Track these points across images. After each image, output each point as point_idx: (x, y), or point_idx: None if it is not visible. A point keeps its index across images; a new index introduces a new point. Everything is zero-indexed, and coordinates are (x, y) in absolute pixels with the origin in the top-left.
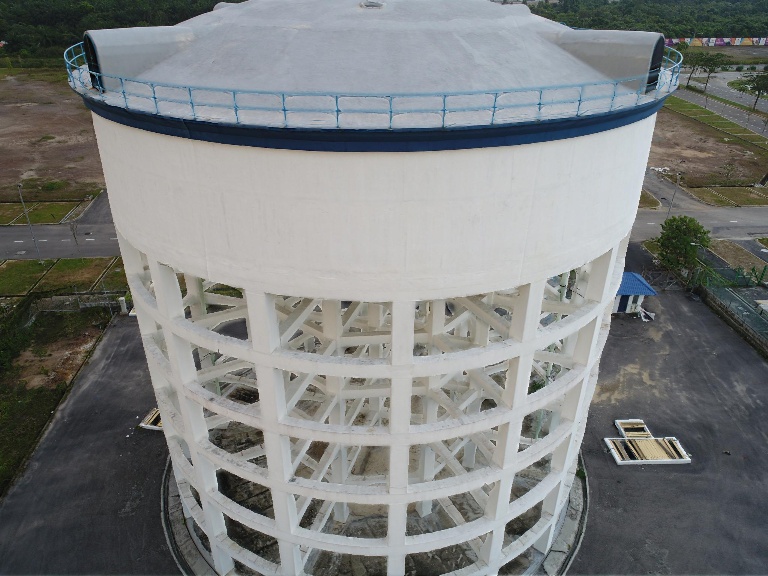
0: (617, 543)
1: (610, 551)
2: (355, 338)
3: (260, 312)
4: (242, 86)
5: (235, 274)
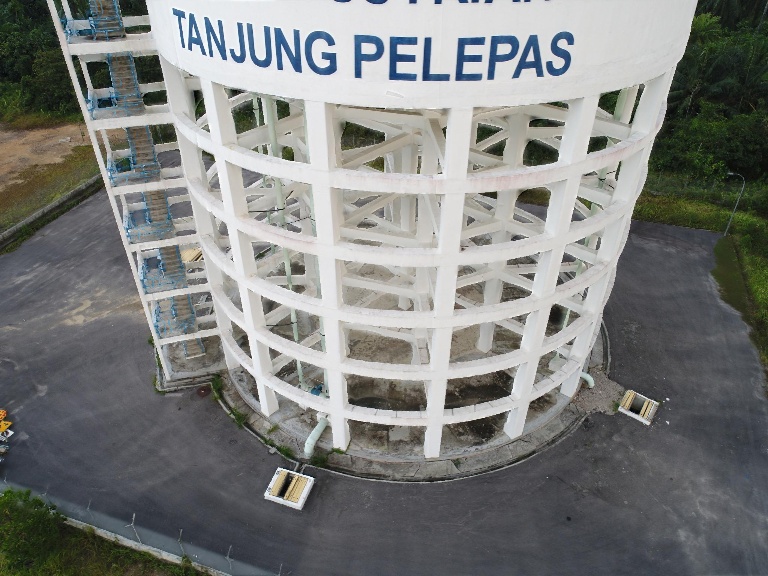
0: None
1: None
2: None
3: None
4: None
5: None
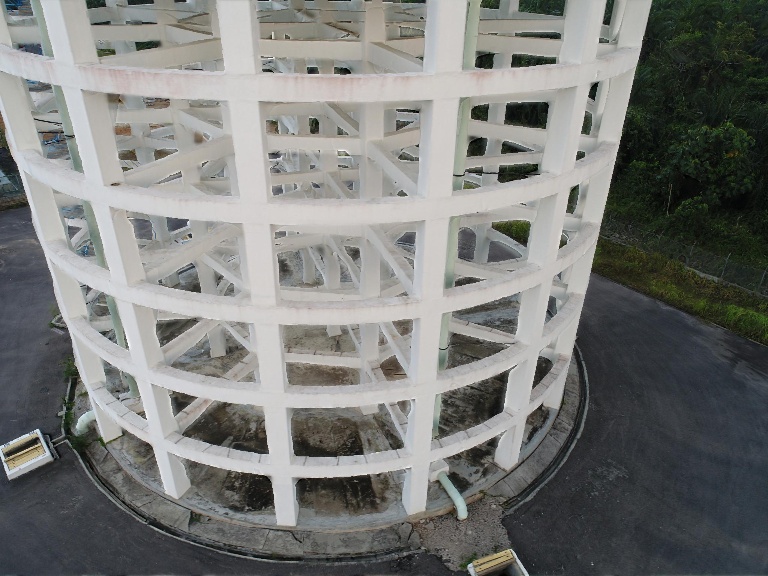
0: None
1: None
2: None
3: None
4: None
5: None
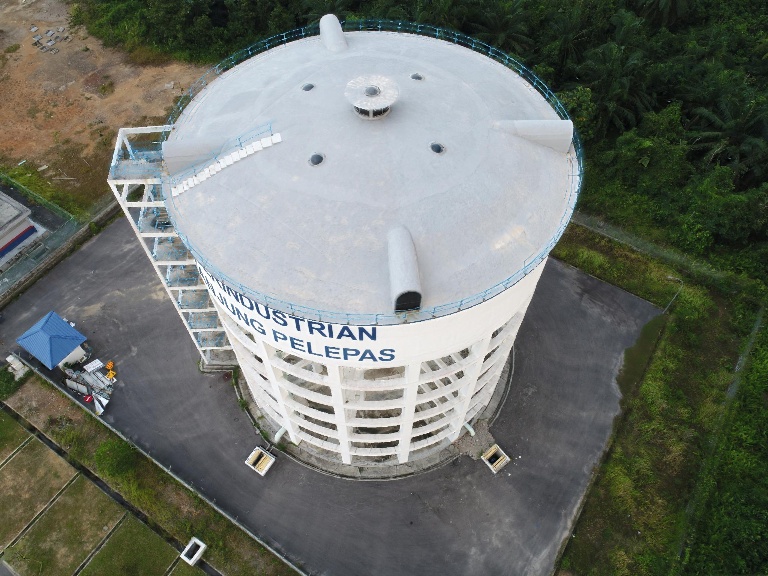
0: None
1: None
2: None
3: None
4: (509, 86)
5: None
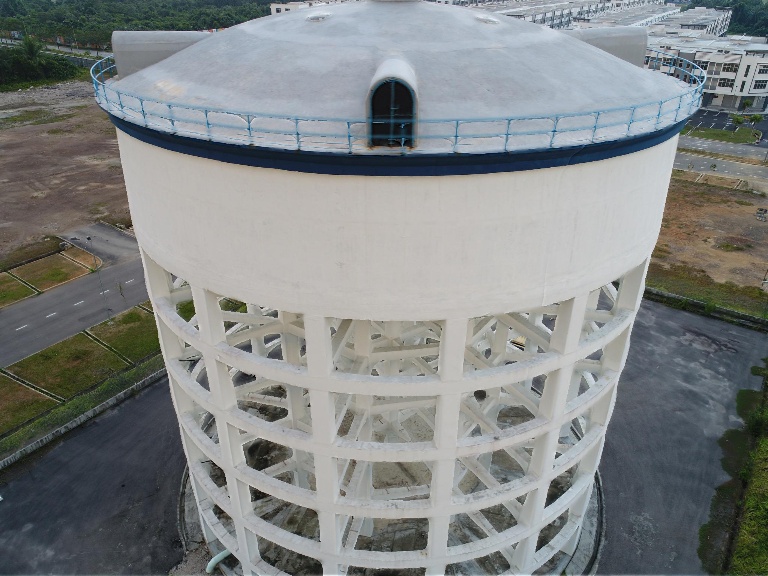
0: None
1: None
2: (477, 335)
3: (581, 313)
4: (560, 106)
5: (571, 286)
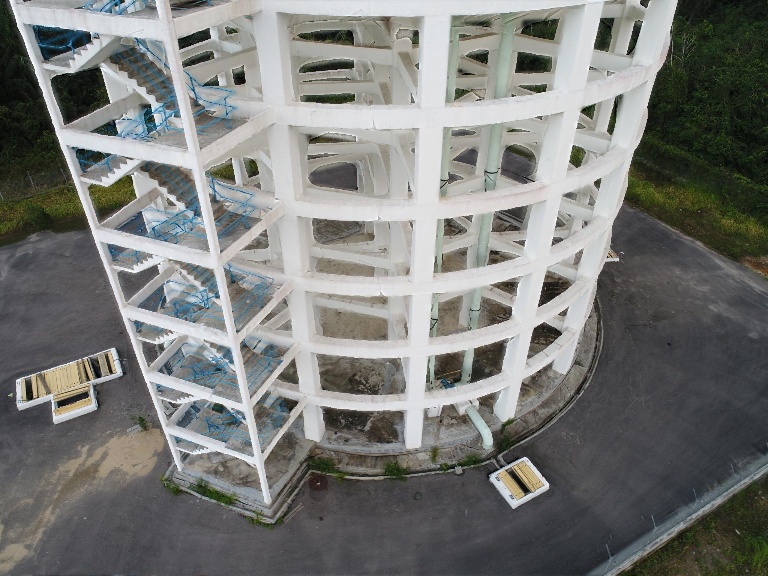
0: (141, 285)
1: (149, 278)
2: None
3: None
4: None
5: None
